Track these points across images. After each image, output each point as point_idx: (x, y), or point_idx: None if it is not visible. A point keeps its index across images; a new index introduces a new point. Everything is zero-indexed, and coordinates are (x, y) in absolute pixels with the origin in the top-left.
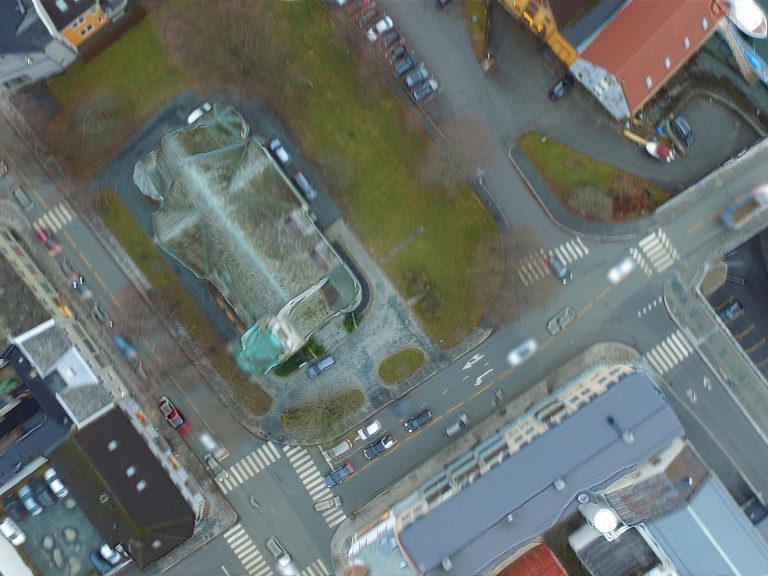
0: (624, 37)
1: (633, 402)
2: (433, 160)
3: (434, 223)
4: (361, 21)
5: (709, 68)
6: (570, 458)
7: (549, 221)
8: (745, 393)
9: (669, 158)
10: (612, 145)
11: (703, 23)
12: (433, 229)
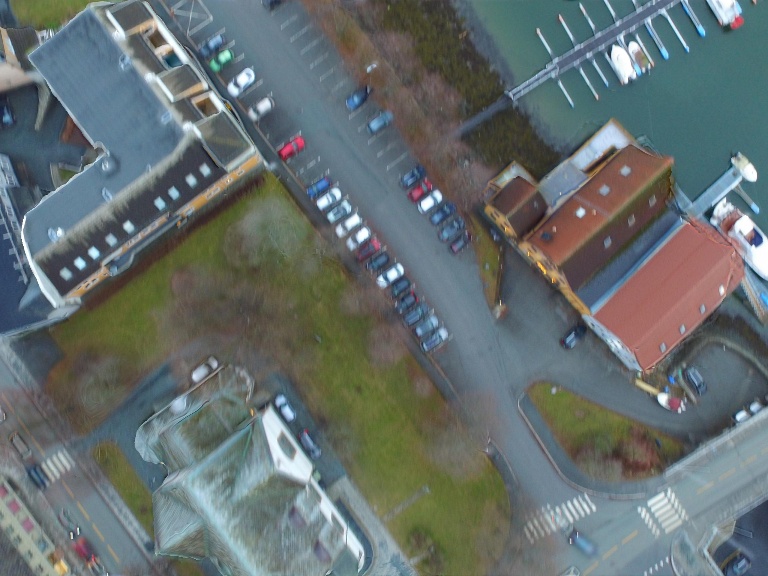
0: (639, 306)
1: None
2: (441, 420)
3: (440, 482)
4: (371, 267)
5: (723, 311)
6: None
7: (557, 476)
8: None
9: (680, 409)
10: (623, 393)
11: (720, 290)
12: (439, 488)
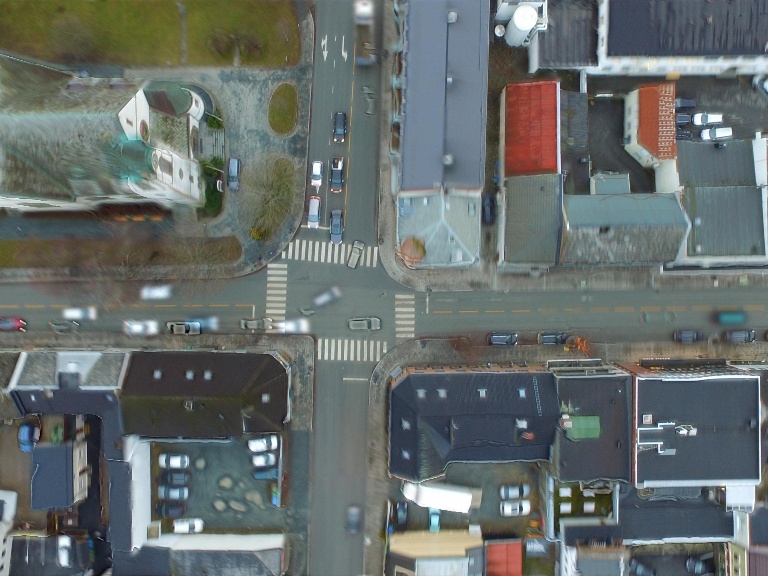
0: None
1: None
2: None
3: None
4: None
5: None
6: (444, 1)
7: None
8: None
9: None
10: None
11: None
12: None
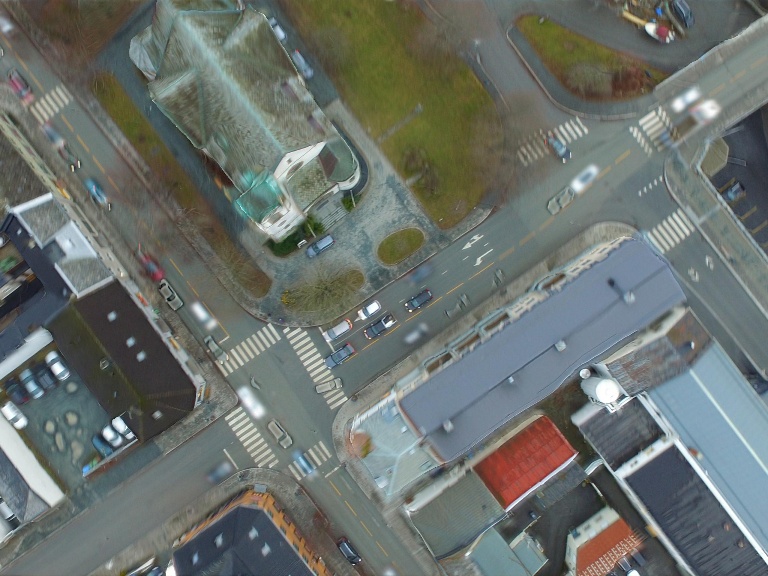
0: None
1: (634, 265)
2: (430, 37)
3: (432, 101)
4: None
5: None
6: (571, 324)
7: (548, 101)
8: (747, 271)
9: (668, 39)
10: (611, 27)
11: None
12: (431, 108)
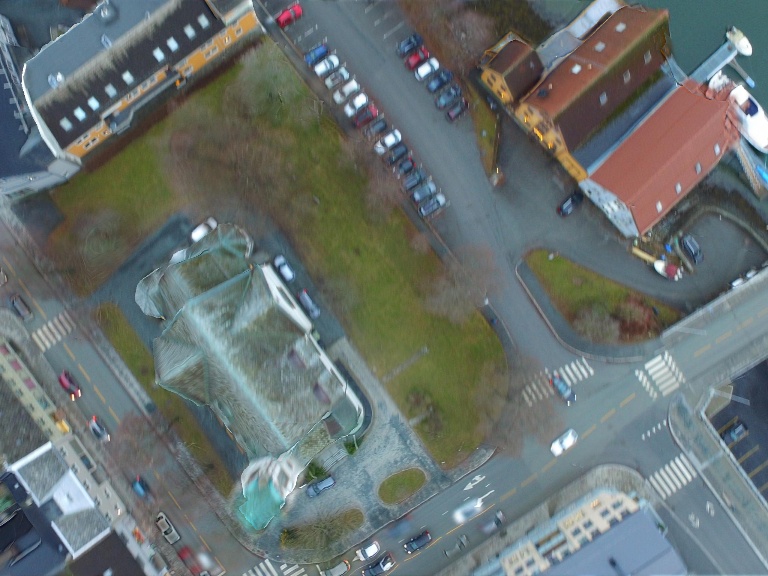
0: (635, 163)
1: (636, 544)
2: (439, 280)
3: (438, 343)
4: (369, 133)
5: (719, 183)
6: None
7: (554, 340)
8: (748, 519)
9: (677, 277)
10: (620, 262)
11: (715, 149)
12: (437, 349)
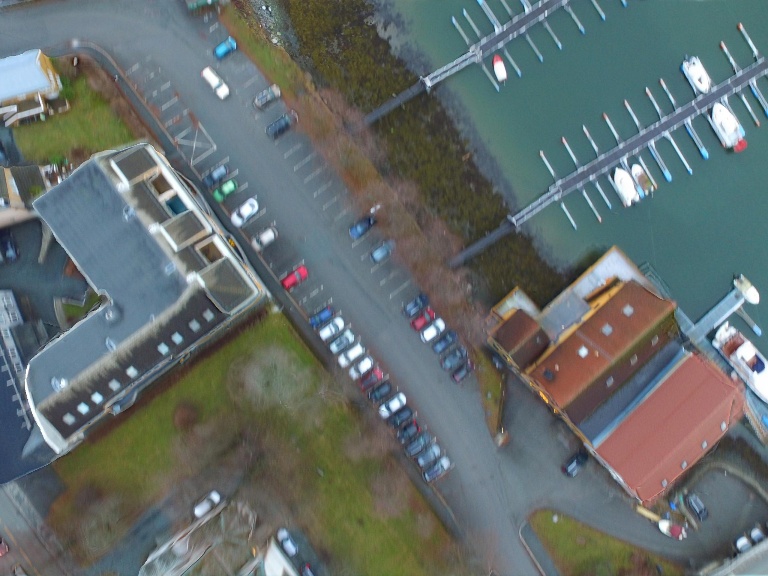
0: (641, 444)
1: None
2: (443, 553)
3: None
4: (374, 397)
5: (725, 435)
6: None
7: None
8: None
9: (681, 536)
10: (624, 519)
11: (722, 426)
12: None
